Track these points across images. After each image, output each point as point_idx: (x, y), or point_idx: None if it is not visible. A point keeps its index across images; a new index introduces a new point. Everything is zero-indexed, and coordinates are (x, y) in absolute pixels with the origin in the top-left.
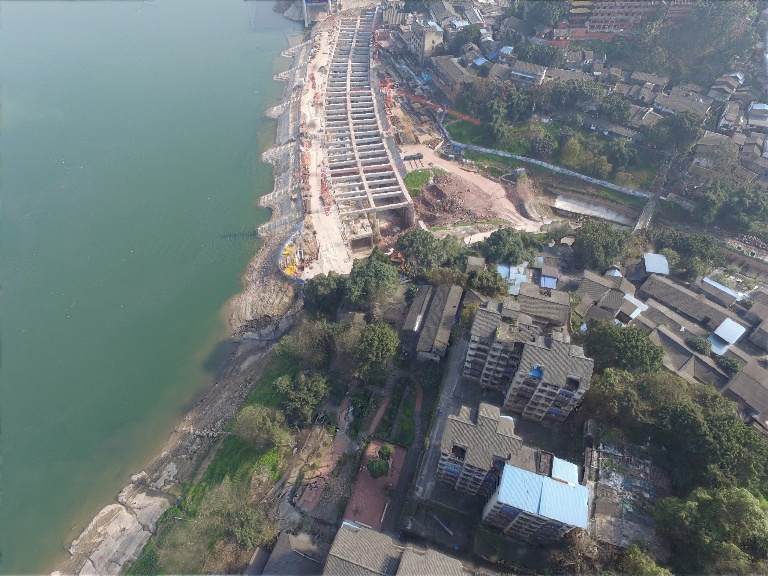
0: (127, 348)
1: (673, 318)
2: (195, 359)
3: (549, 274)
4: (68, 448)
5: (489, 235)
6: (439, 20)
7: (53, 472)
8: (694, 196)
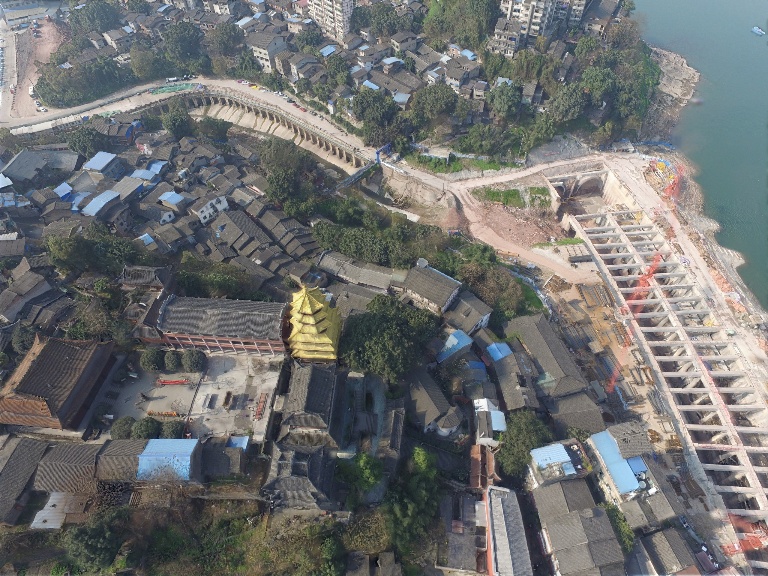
0: (749, 151)
1: (410, 78)
2: (695, 144)
3: (482, 84)
4: (733, 114)
5: (496, 180)
6: (610, 526)
7: (731, 109)
8: (311, 166)
